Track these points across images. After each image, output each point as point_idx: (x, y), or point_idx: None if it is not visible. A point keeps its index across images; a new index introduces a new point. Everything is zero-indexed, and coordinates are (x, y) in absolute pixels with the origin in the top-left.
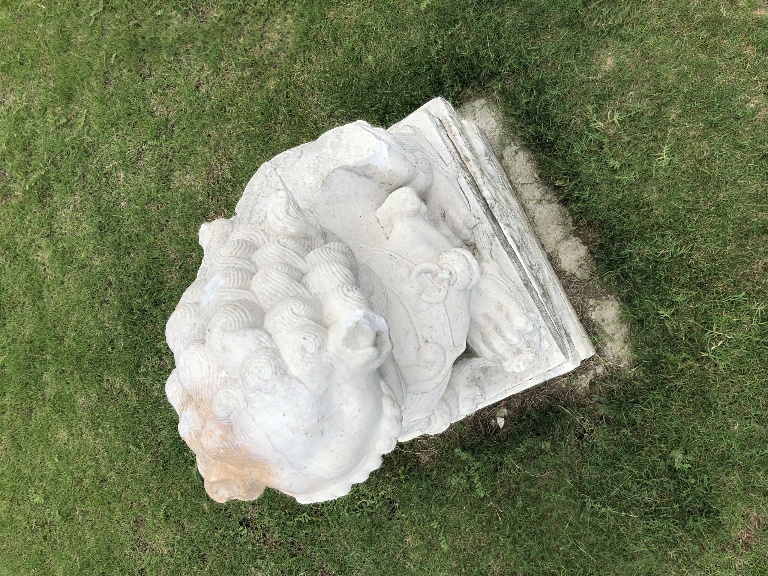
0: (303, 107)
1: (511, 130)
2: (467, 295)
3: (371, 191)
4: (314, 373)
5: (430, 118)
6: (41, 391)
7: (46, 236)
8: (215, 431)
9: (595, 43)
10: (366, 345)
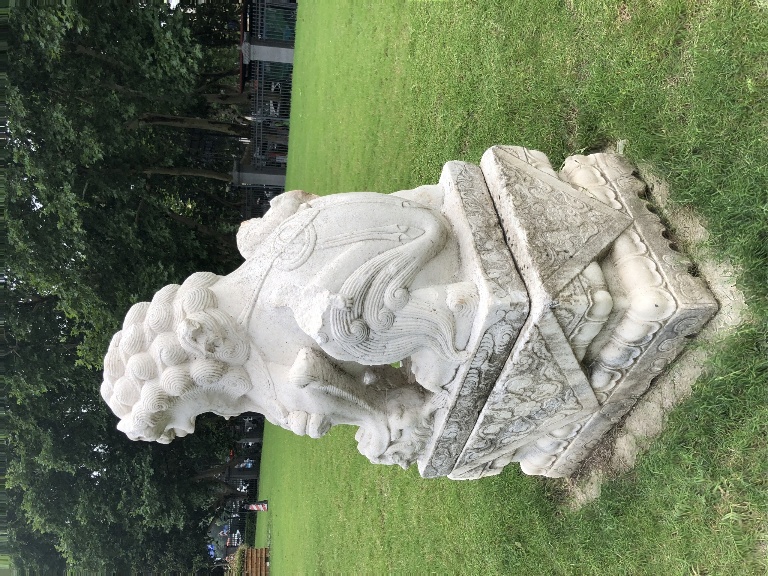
0: (693, 1)
1: None
2: None
3: None
4: None
5: (490, 315)
6: None
7: None
8: None
9: None
10: None
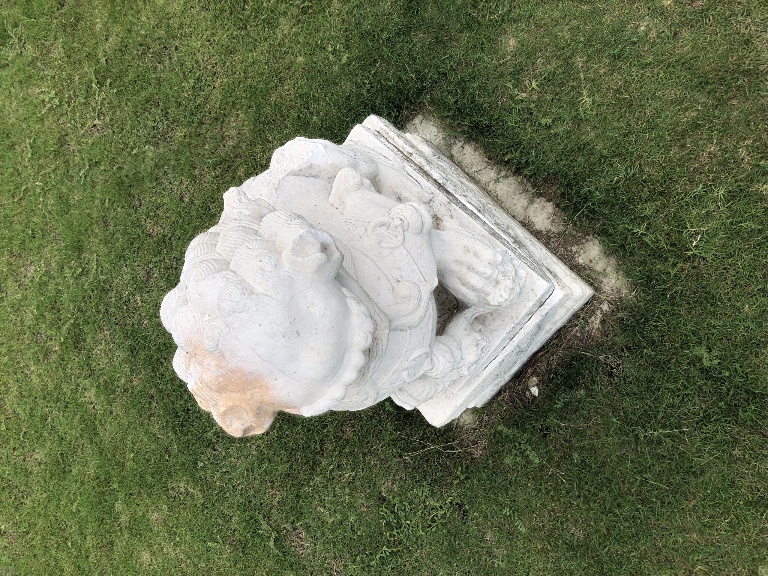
0: None
1: (451, 130)
2: (425, 238)
3: (321, 186)
4: (276, 285)
5: (366, 130)
6: (117, 522)
7: (88, 377)
8: (210, 363)
9: (494, 33)
10: (314, 252)
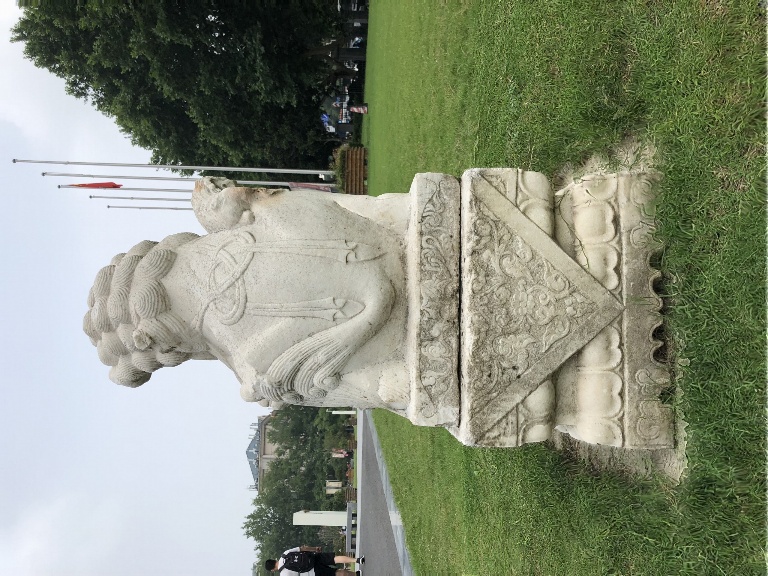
0: None
1: None
2: None
3: None
4: None
5: None
6: None
7: None
8: None
9: None
10: None
